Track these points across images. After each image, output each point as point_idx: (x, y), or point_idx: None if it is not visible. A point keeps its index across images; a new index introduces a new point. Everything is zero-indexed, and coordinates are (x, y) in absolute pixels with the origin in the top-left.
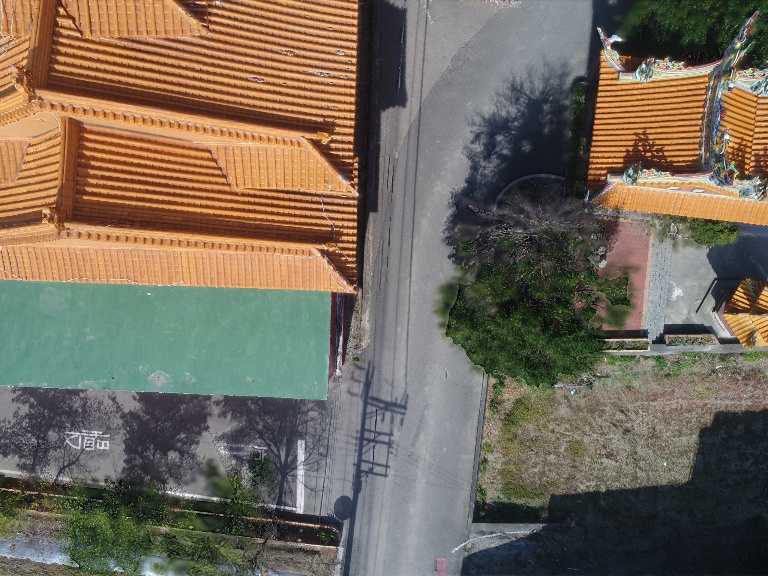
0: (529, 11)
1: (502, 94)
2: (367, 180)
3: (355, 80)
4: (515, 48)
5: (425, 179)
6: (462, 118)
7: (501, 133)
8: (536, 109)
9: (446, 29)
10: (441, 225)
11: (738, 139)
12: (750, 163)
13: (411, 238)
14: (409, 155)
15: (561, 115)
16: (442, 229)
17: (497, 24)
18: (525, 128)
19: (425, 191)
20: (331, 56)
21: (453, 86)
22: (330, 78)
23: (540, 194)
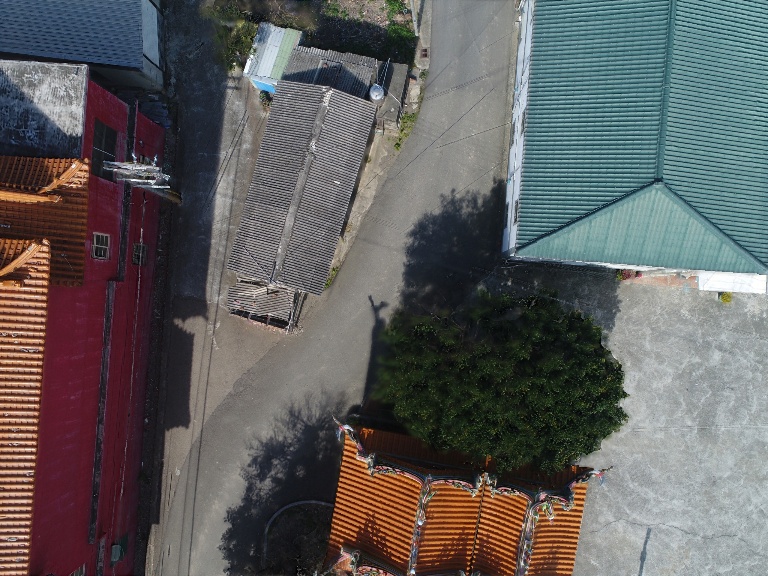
0: (311, 340)
1: (280, 420)
2: (151, 493)
3: (28, 560)
4: (295, 376)
5: (204, 497)
6: (241, 442)
7: (277, 457)
8: (312, 435)
9: (230, 355)
10: (217, 541)
11: (459, 530)
12: (475, 546)
13: (189, 551)
14: (190, 474)
15: (335, 442)
16: (218, 545)
17: (279, 352)
18: (300, 454)
19: (203, 508)
20: (2, 543)
21: (234, 410)
22: (1, 564)
23: (310, 519)
